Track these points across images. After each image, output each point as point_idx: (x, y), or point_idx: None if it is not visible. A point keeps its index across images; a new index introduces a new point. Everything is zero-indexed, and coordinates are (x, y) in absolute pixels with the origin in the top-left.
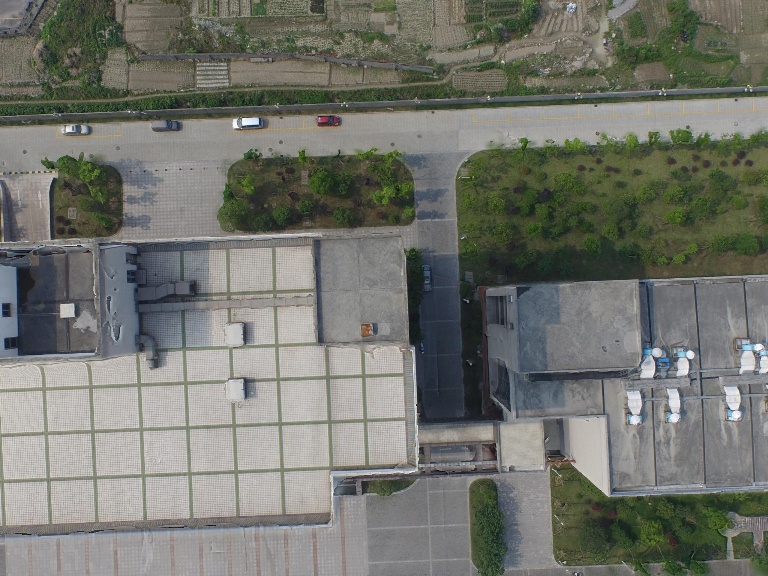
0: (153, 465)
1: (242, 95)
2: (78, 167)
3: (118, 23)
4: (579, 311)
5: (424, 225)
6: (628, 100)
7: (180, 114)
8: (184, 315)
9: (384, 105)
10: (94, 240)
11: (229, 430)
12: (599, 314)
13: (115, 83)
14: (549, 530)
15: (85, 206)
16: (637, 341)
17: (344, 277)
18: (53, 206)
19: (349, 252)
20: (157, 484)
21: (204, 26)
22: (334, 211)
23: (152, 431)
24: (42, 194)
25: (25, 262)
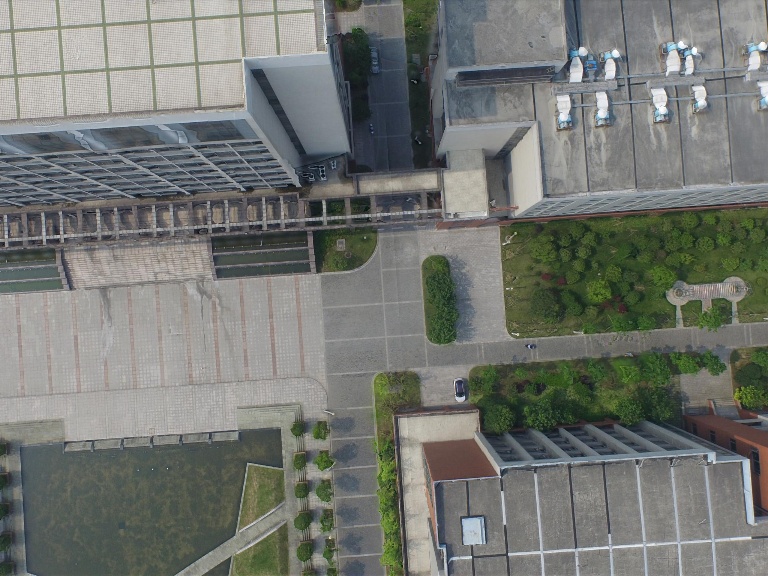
0: (72, 62)
1: None
2: None
3: None
4: (505, 9)
5: (371, 10)
6: None
7: None
8: None
9: None
10: None
11: (144, 26)
12: (525, 11)
13: None
14: (501, 304)
15: None
16: (562, 36)
17: None
18: None
19: None
20: (76, 81)
21: None
22: None
23: (70, 29)
24: None
25: None
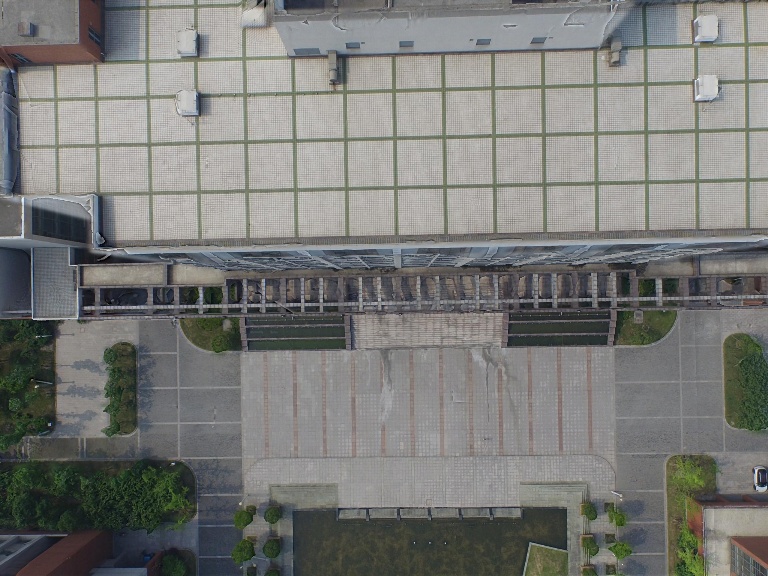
0: (607, 172)
1: None
2: None
3: None
4: None
5: None
6: None
7: None
8: (645, 11)
9: None
10: None
11: (691, 136)
12: None
13: None
14: None
15: None
16: None
17: None
18: None
19: None
20: (611, 193)
21: None
22: None
23: (608, 135)
24: None
25: None
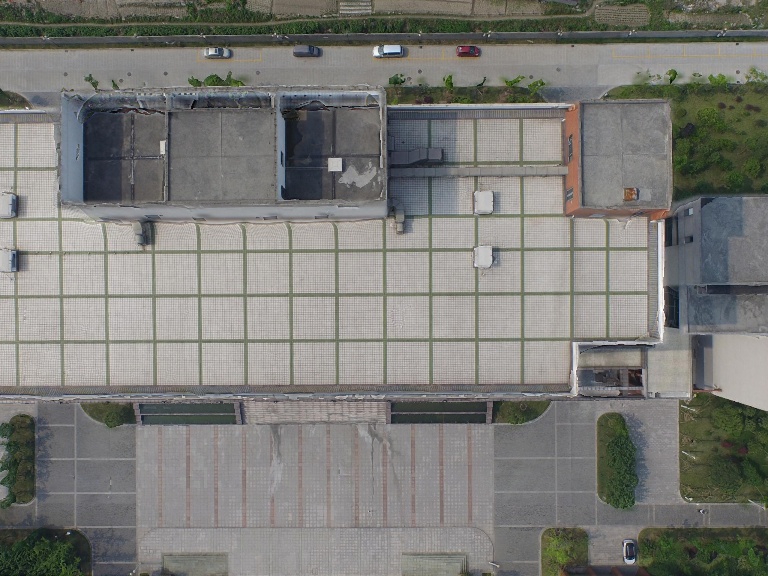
0: (395, 330)
1: (385, 22)
2: None
3: None
4: (762, 224)
5: None
6: None
7: (321, 40)
8: (431, 183)
9: (525, 37)
10: None
11: (471, 298)
12: None
13: (259, 7)
14: (676, 466)
15: None
16: None
17: (607, 142)
18: None
19: (613, 117)
20: (398, 349)
21: None
22: None
23: (395, 296)
24: None
25: (293, 117)
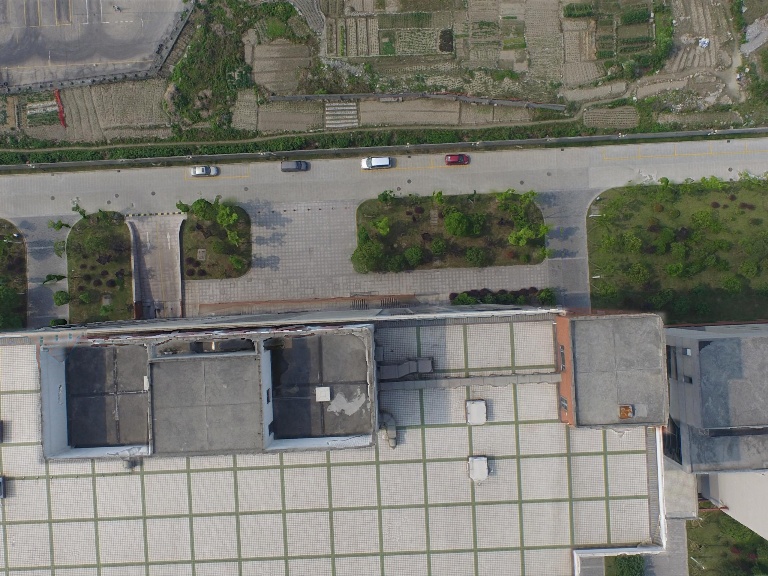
0: (391, 543)
1: (372, 135)
2: (216, 211)
3: (247, 64)
4: (761, 365)
5: (555, 264)
6: (761, 135)
7: (308, 154)
8: (422, 392)
9: (514, 143)
10: (367, 329)
11: (468, 508)
12: None
13: (245, 124)
14: (685, 572)
15: (218, 248)
16: None
17: (600, 358)
18: (183, 248)
19: (604, 332)
20: (395, 562)
21: (333, 66)
22: (467, 251)
23: (390, 509)
24: (171, 235)
25: (278, 344)
